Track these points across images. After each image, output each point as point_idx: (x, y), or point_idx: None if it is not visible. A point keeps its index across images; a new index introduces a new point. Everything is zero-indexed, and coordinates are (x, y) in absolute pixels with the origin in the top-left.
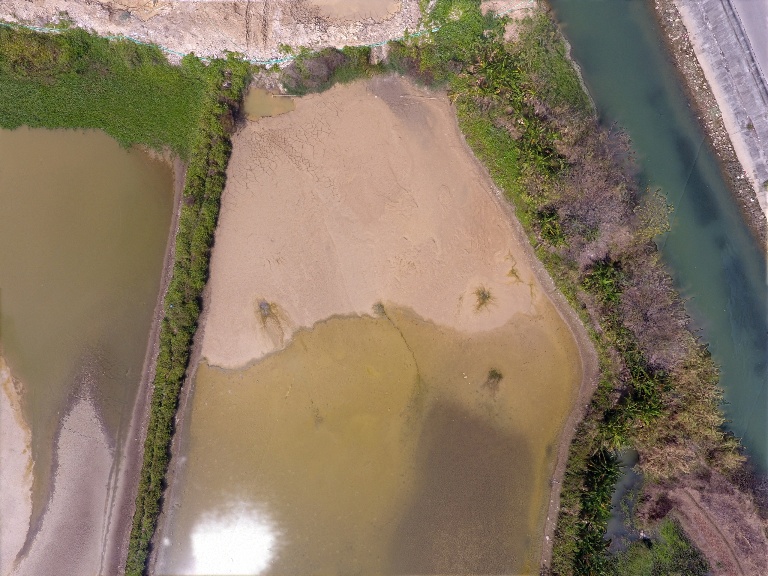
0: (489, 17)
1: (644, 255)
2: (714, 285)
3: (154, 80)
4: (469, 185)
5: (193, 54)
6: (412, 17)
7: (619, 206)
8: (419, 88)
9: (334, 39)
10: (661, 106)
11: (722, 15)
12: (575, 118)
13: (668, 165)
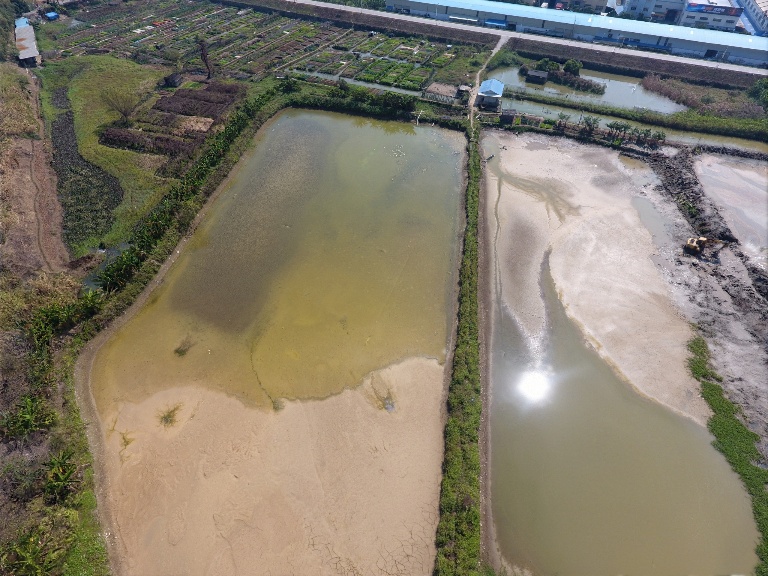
0: None
1: None
2: None
3: None
4: (141, 547)
5: None
6: None
7: None
8: None
9: None
10: None
11: None
12: None
13: None
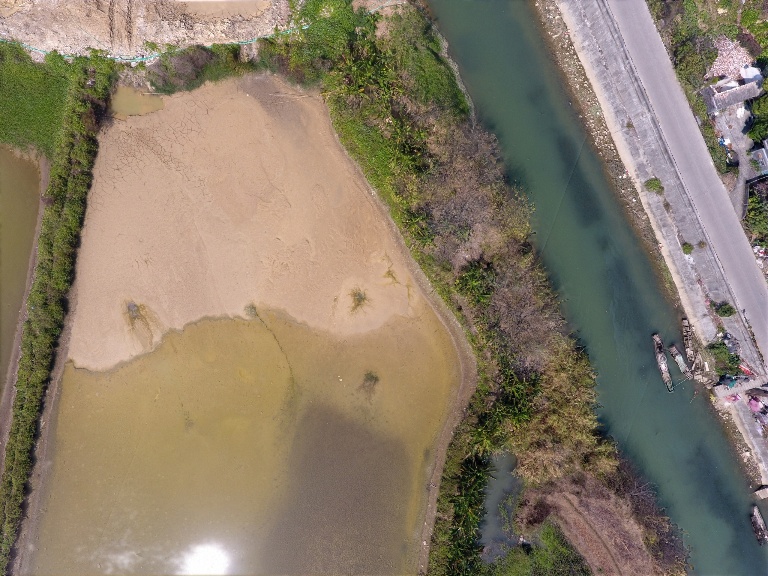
0: (359, 14)
1: (516, 256)
2: (597, 286)
3: (18, 78)
4: (344, 185)
5: (56, 52)
6: (282, 14)
7: (490, 206)
8: (292, 86)
9: (201, 36)
10: (542, 104)
11: (597, 12)
12: (443, 117)
13: (549, 164)
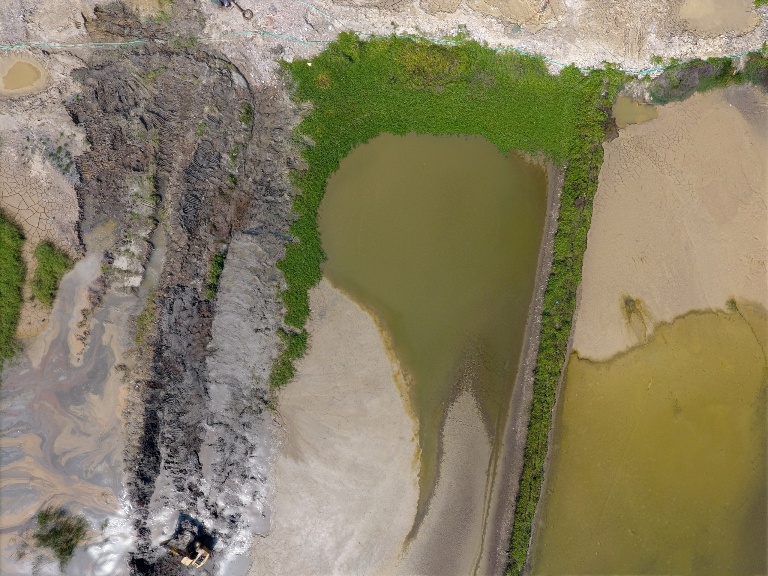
0: None
1: None
2: None
3: (534, 89)
4: None
5: (574, 65)
6: None
7: None
8: None
9: (701, 51)
10: None
11: None
12: None
13: None
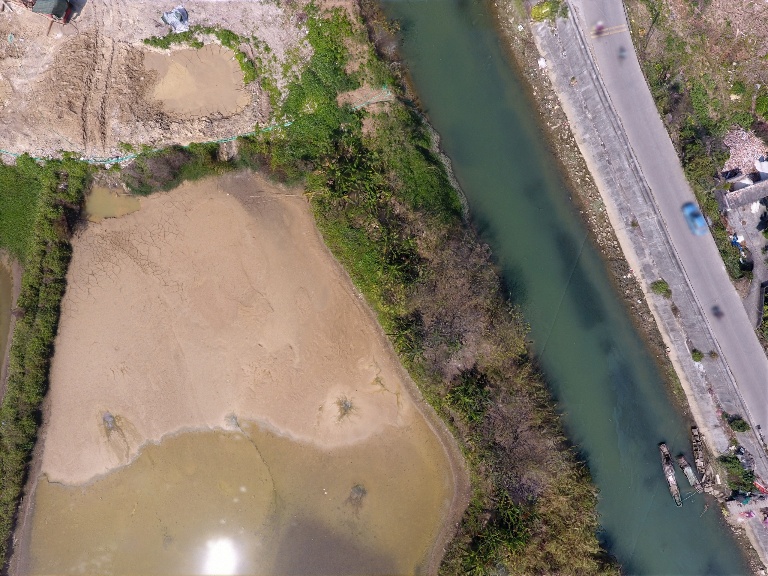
0: (344, 111)
1: (511, 369)
2: (599, 392)
3: None
4: (329, 287)
5: (27, 154)
6: (263, 111)
7: (484, 315)
8: (274, 184)
9: (178, 136)
10: (540, 199)
11: (599, 106)
12: None
13: (547, 264)
